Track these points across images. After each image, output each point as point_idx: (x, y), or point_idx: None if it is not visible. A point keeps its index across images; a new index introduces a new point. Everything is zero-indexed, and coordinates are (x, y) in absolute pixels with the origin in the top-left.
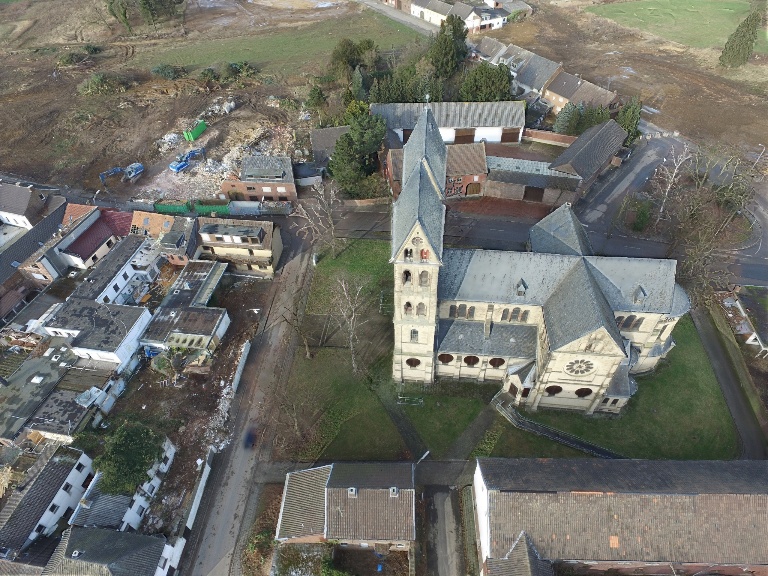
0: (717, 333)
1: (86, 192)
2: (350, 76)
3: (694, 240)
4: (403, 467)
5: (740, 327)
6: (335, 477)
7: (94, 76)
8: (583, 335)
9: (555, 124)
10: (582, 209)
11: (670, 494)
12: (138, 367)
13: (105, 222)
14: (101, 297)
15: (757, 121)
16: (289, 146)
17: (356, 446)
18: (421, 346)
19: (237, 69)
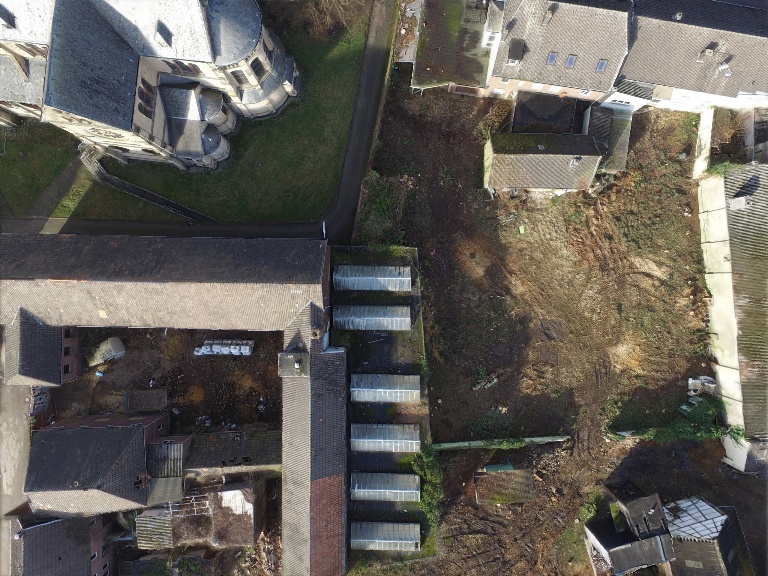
0: (386, 56)
1: None
2: None
3: None
4: None
5: (404, 52)
6: None
7: None
8: None
9: None
10: None
11: (141, 282)
12: None
13: None
14: None
15: None
16: None
17: None
18: None
19: None
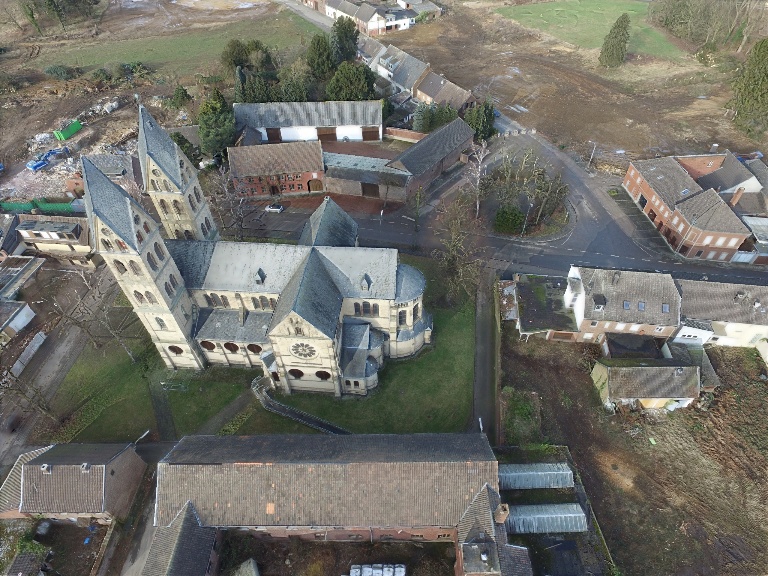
0: (493, 320)
1: None
2: None
3: (508, 233)
4: (118, 446)
5: (509, 313)
6: (43, 456)
7: None
8: (282, 319)
9: (413, 122)
10: (416, 204)
11: (324, 463)
12: None
13: None
14: None
15: (616, 119)
16: None
17: (109, 429)
18: (173, 334)
19: (130, 69)
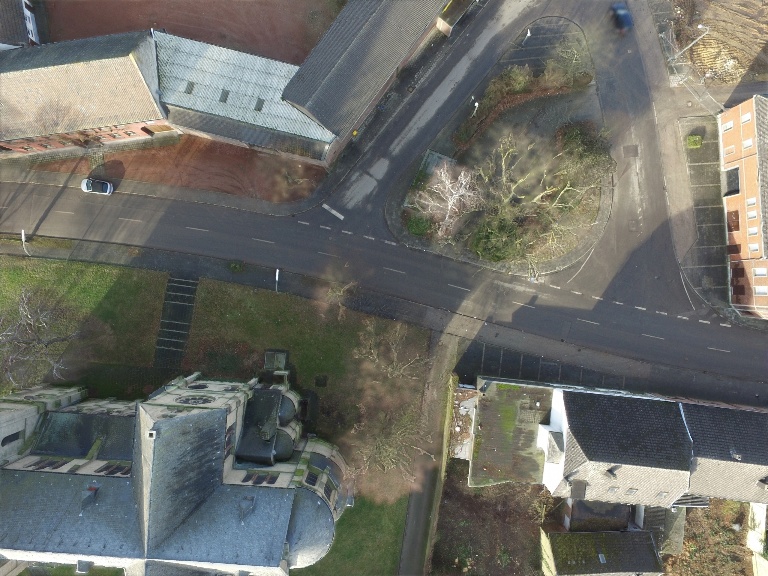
0: (440, 439)
1: None
2: None
3: None
4: None
5: (459, 450)
6: None
7: None
8: None
9: None
10: (345, 172)
11: None
12: None
13: None
14: None
15: None
16: None
17: None
18: None
19: None
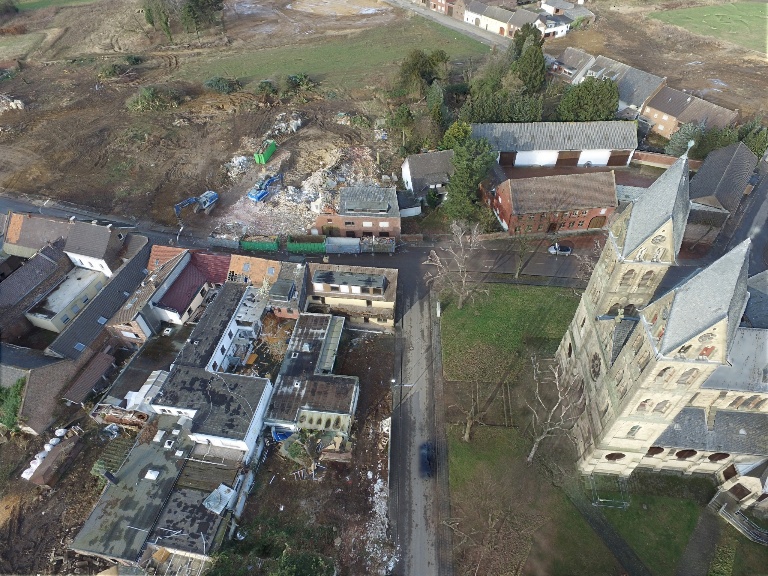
0: None
1: (156, 225)
2: (423, 90)
3: None
4: None
5: None
6: None
7: (144, 90)
8: None
9: (669, 146)
10: (725, 246)
11: None
12: (264, 452)
13: (196, 267)
14: (211, 364)
15: None
16: (374, 170)
17: (559, 566)
18: (636, 442)
19: (297, 82)
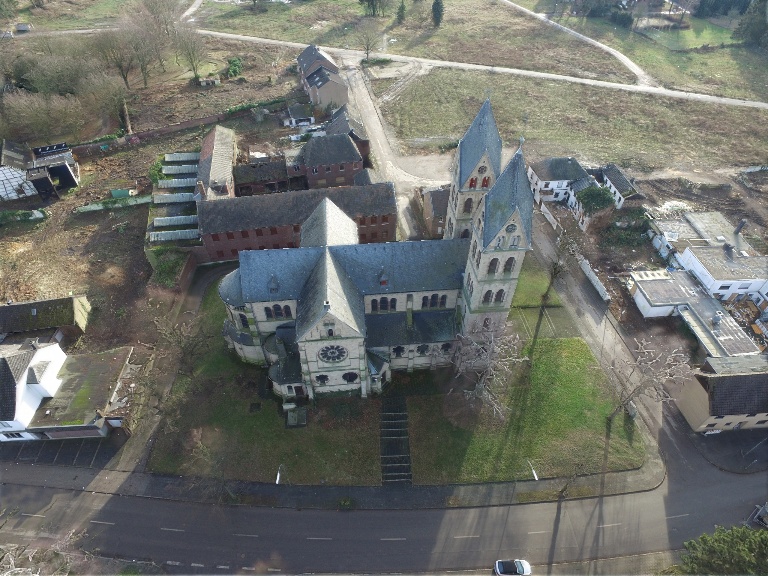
0: None
1: None
2: None
3: None
4: (439, 212)
5: None
6: None
7: None
8: None
9: None
10: None
11: (299, 191)
12: None
13: None
14: None
15: None
16: None
17: None
18: None
19: None
